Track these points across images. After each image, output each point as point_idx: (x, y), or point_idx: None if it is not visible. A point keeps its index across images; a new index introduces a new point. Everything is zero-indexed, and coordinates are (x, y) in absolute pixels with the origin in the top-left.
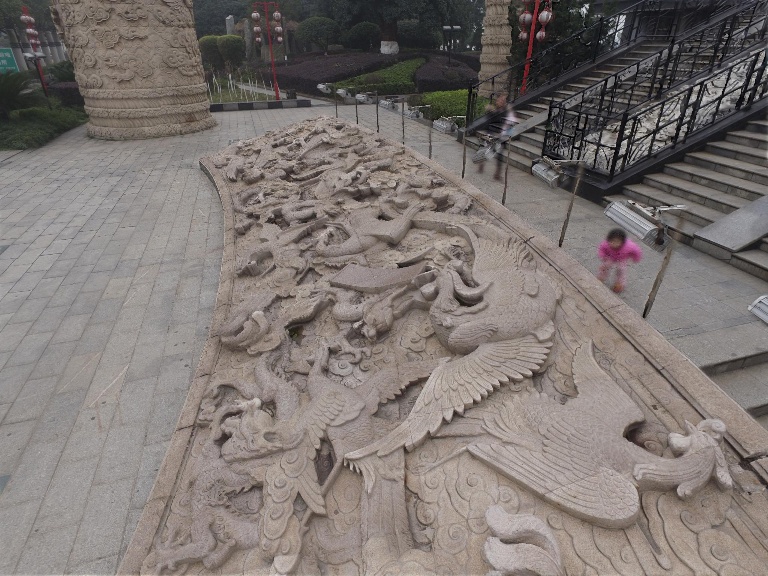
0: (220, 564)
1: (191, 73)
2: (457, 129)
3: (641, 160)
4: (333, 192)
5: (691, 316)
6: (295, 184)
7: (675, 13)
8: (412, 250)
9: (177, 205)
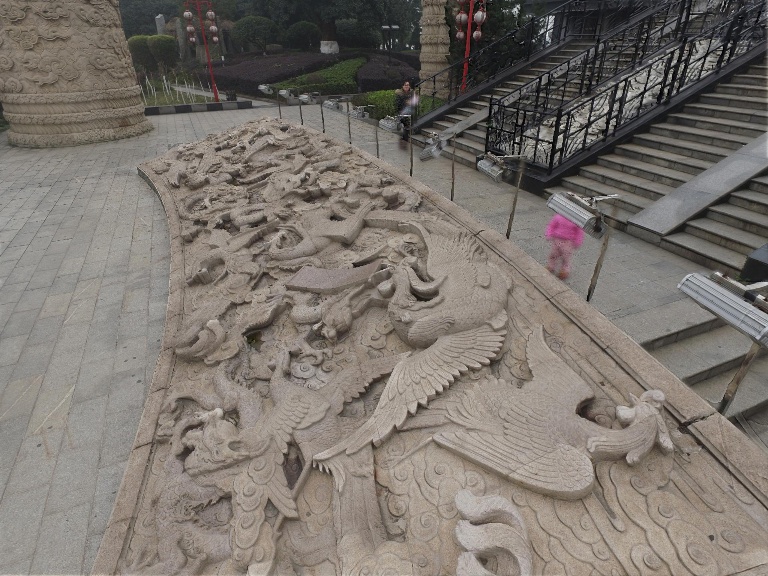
0: None
1: (122, 75)
2: None
3: (576, 153)
4: None
5: (629, 297)
6: (242, 188)
7: (599, 13)
8: (366, 249)
9: (116, 214)
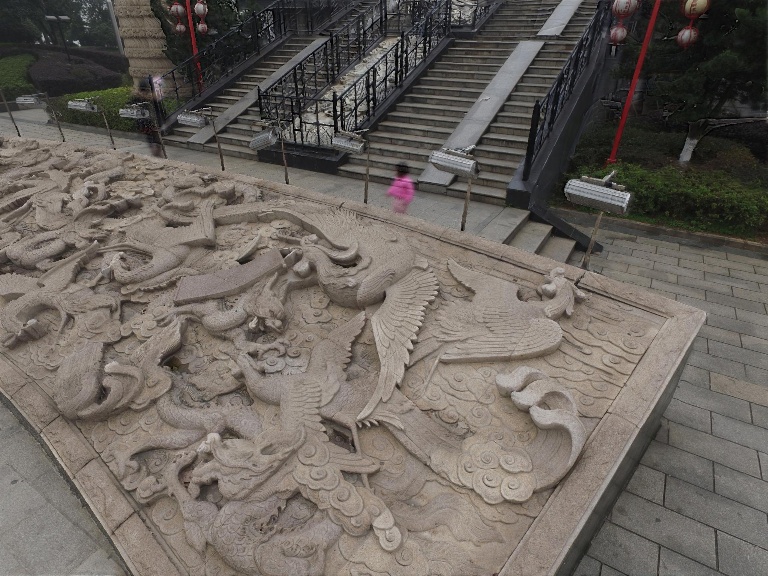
0: (323, 573)
1: None
2: (134, 132)
3: None
4: None
5: None
6: None
7: (307, 11)
8: (235, 246)
9: None
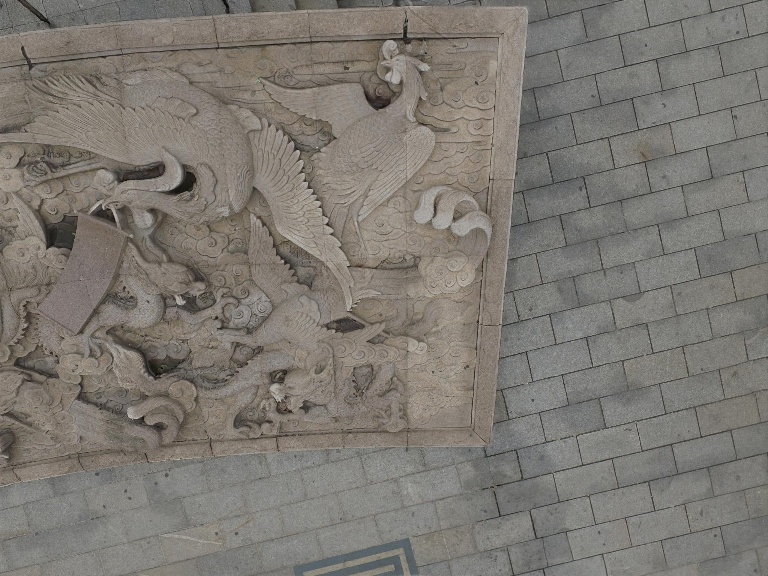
0: None
1: None
2: None
3: None
4: None
5: None
6: None
7: None
8: (3, 223)
9: None
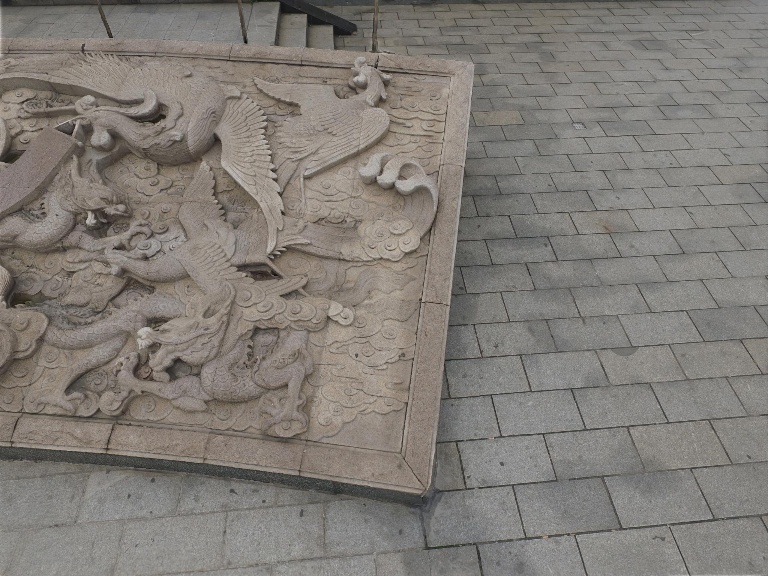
0: None
1: None
2: None
3: None
4: None
5: None
6: None
7: None
8: None
9: None
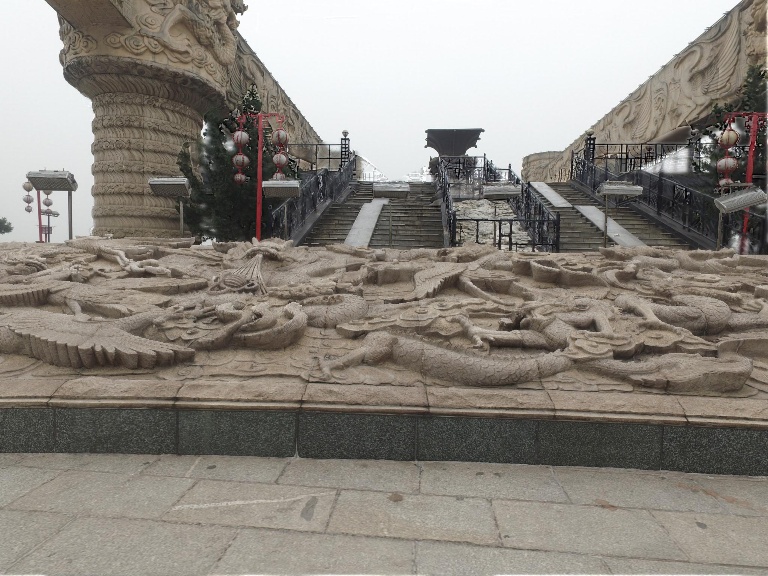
0: None
1: None
2: None
3: None
4: (604, 282)
5: None
6: None
7: (333, 184)
8: None
9: None
